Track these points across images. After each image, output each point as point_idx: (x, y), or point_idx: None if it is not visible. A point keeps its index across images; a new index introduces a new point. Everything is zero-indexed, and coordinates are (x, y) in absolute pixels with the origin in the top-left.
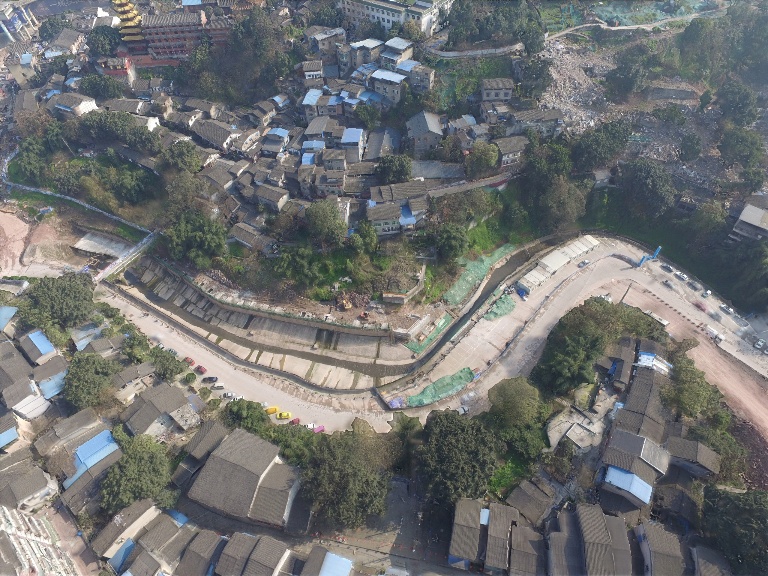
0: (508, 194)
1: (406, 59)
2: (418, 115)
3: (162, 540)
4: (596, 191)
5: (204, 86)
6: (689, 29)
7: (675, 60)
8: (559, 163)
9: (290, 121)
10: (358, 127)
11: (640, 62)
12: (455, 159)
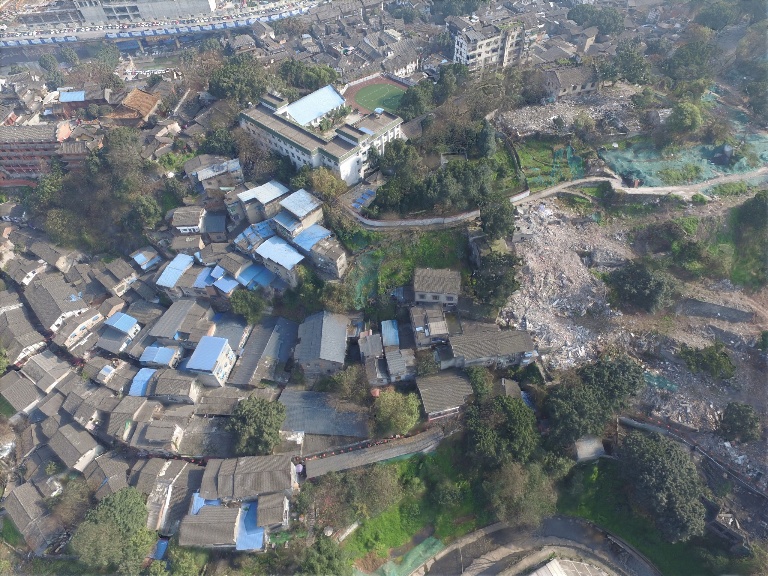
0: (439, 458)
1: (311, 224)
2: (316, 318)
3: None
4: (579, 466)
5: (52, 229)
6: (751, 208)
7: (724, 262)
8: (515, 439)
9: (150, 295)
10: (238, 316)
11: (668, 251)
12: (361, 397)
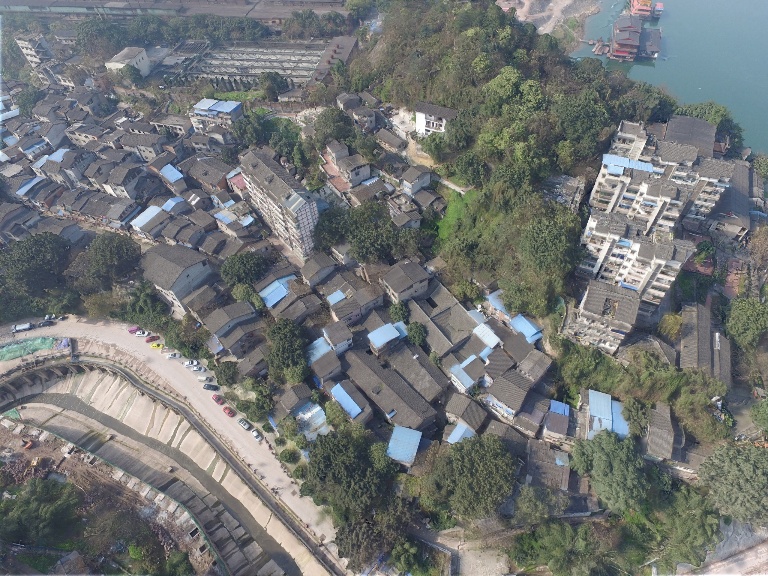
0: None
1: None
2: None
3: (232, 245)
4: None
5: None
6: None
7: None
8: None
9: None
10: None
11: None
12: None
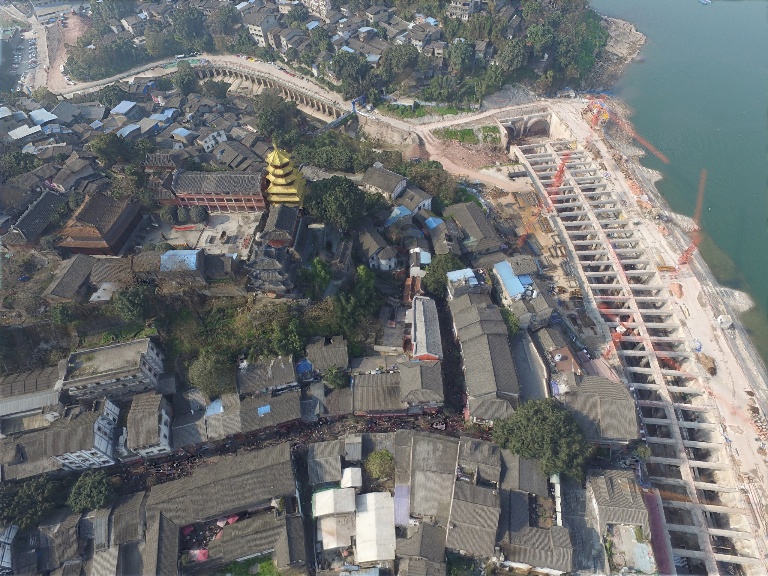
0: None
1: None
2: None
3: None
4: None
5: None
6: None
7: None
8: None
9: None
10: None
11: None
12: None
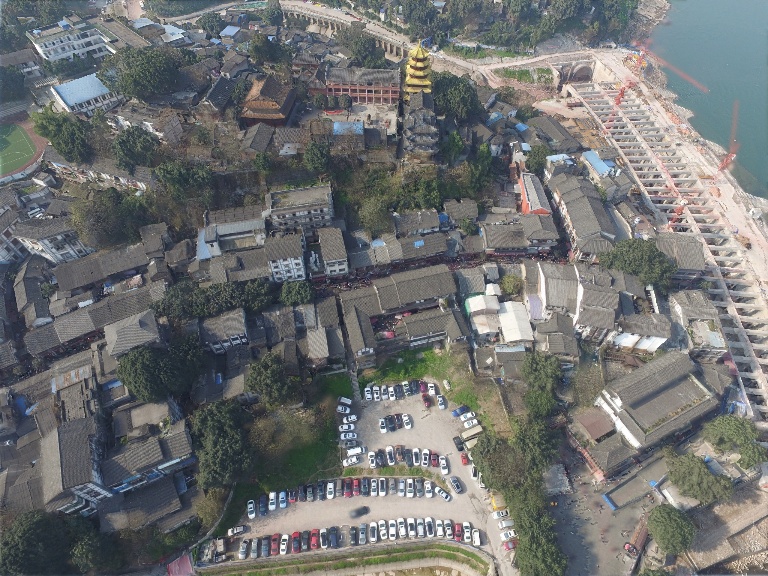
0: None
1: None
2: None
3: None
4: None
5: None
6: None
7: None
8: None
9: None
10: None
11: None
12: None
